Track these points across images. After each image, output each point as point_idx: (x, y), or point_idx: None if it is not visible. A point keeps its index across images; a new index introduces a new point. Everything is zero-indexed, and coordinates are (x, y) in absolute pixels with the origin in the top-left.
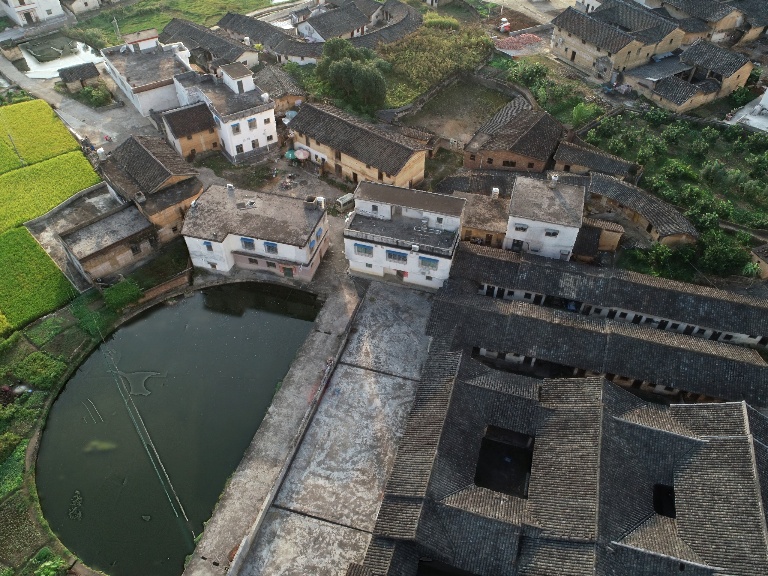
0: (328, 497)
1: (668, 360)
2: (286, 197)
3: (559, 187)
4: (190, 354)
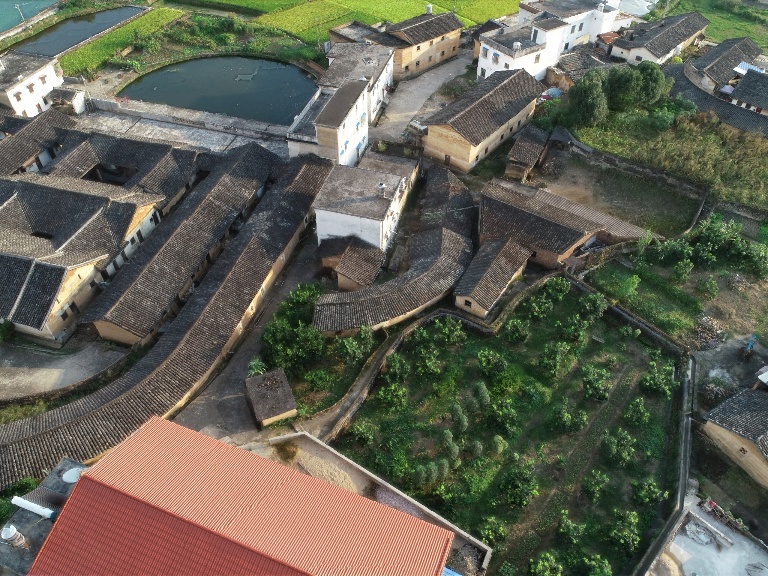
0: (137, 134)
1: (147, 257)
2: (379, 74)
3: (382, 201)
4: (262, 87)
